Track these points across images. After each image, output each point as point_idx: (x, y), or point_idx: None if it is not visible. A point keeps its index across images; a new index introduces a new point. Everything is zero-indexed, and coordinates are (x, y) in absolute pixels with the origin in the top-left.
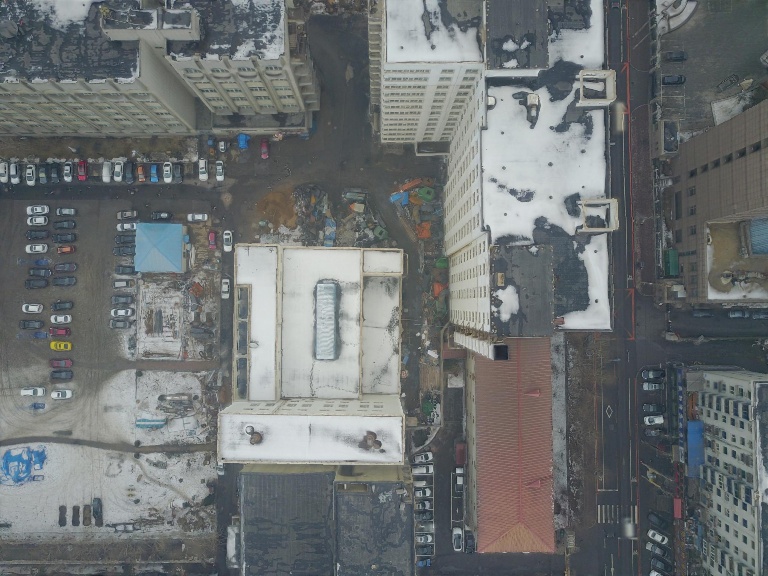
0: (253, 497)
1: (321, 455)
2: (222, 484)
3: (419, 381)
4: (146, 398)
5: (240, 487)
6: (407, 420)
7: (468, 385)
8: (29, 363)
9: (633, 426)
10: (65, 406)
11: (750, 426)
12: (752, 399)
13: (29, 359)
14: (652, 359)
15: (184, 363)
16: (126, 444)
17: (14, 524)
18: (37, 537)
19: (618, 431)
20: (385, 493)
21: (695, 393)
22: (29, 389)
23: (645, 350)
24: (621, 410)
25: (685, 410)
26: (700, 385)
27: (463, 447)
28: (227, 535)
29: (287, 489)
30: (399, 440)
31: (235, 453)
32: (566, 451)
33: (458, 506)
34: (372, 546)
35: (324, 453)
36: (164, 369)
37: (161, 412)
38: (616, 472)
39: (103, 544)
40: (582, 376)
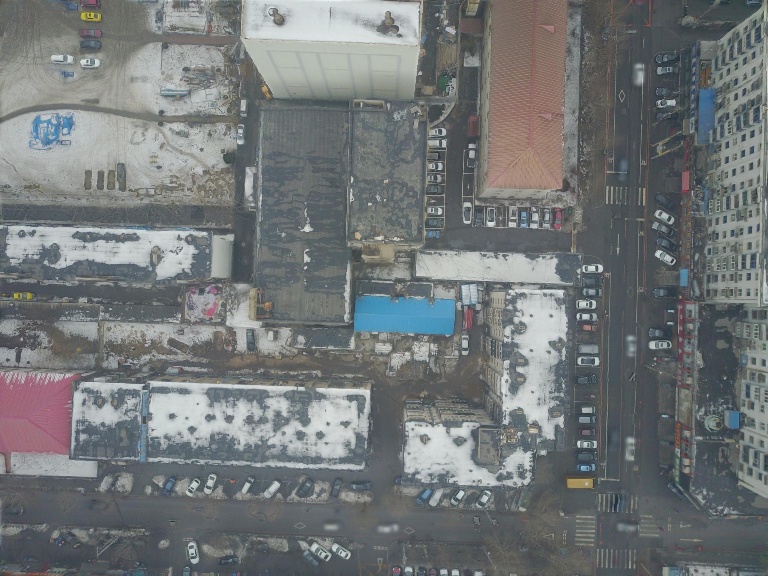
0: (272, 132)
1: (340, 37)
2: (241, 154)
3: (436, 60)
4: (171, 69)
5: (259, 123)
6: (423, 88)
7: (484, 57)
8: (60, 34)
9: (645, 111)
10: (93, 76)
11: (762, 47)
12: (765, 16)
13: (60, 30)
14: (667, 46)
15: (208, 37)
16: (150, 113)
17: (42, 186)
18: (63, 198)
19: (630, 115)
20: (400, 112)
21: (708, 64)
22: (60, 55)
23: (660, 37)
24: (634, 95)
25: (698, 79)
26: (714, 53)
27: (476, 119)
28: (245, 174)
29: (305, 124)
30: (416, 25)
31: (258, 34)
32: (577, 132)
33: (469, 182)
34: (385, 161)
35: (343, 35)
36: (189, 43)
37: (185, 84)
38: (626, 155)
39: (126, 208)
40: (597, 59)
